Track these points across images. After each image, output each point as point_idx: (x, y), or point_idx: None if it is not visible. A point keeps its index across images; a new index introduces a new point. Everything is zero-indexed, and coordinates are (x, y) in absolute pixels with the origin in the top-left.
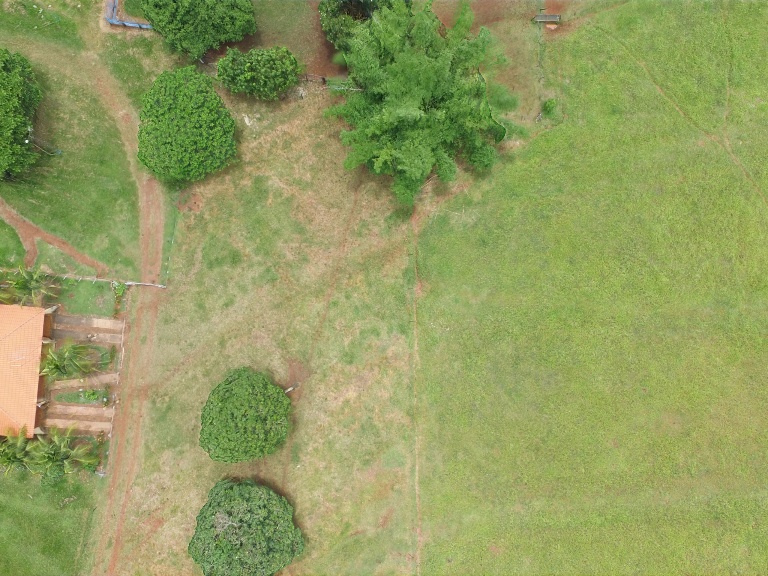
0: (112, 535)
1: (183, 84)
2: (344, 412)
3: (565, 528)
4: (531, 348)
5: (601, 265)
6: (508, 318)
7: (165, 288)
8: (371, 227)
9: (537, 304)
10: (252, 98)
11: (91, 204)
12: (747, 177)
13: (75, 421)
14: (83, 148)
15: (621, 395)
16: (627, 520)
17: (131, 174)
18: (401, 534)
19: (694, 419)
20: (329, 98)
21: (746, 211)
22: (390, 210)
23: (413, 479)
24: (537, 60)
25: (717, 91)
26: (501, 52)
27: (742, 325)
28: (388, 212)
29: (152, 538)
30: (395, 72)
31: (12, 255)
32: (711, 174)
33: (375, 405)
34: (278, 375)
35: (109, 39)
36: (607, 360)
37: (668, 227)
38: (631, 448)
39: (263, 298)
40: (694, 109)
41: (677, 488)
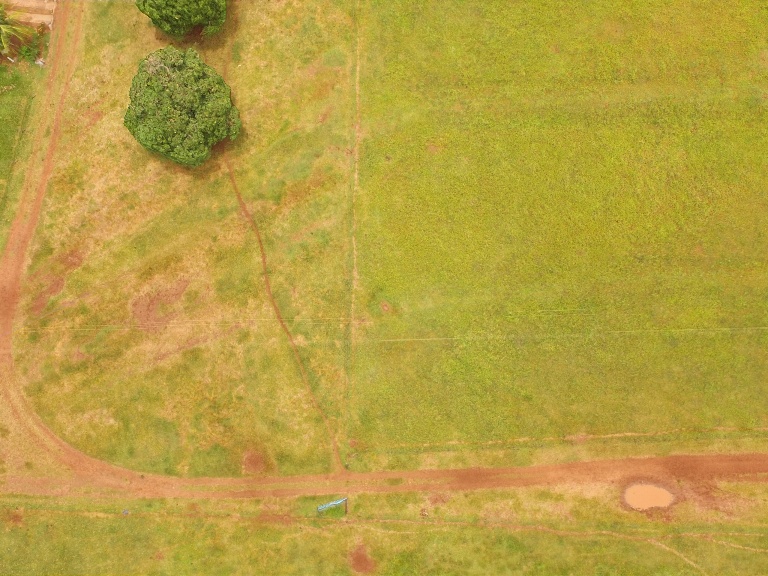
0: (50, 124)
1: None
2: (286, 12)
3: (504, 130)
4: None
5: None
6: None
7: None
8: None
9: None
10: None
11: None
12: None
13: (16, 12)
14: None
15: (564, 2)
16: (566, 122)
17: None
18: (340, 130)
19: (636, 27)
20: None
21: None
22: None
23: (354, 79)
24: None
25: None
26: None
27: None
28: None
29: (91, 130)
30: None
31: None
32: None
33: (318, 6)
34: None
35: None
36: None
37: None
38: (573, 53)
39: None
40: None
41: (617, 93)
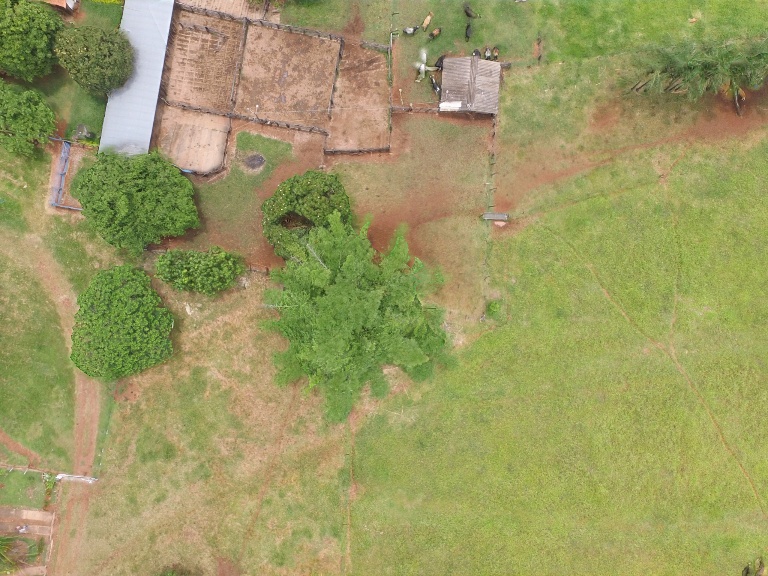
0: None
1: (119, 287)
2: None
3: None
4: (465, 556)
5: (540, 473)
6: (443, 525)
7: (97, 480)
8: (308, 424)
9: (472, 513)
10: (192, 292)
11: (27, 390)
12: (692, 387)
13: None
14: (22, 332)
15: None
16: None
17: (69, 361)
18: None
19: None
20: (272, 289)
21: (689, 423)
22: (328, 407)
23: None
24: (483, 258)
25: (664, 298)
26: (447, 249)
27: (681, 542)
28: (326, 409)
29: None
30: (325, 304)
31: None
32: (655, 383)
33: None
34: (207, 574)
35: (53, 221)
36: (542, 572)
37: (609, 436)
38: None
39: (196, 494)
40: (640, 316)
41: None
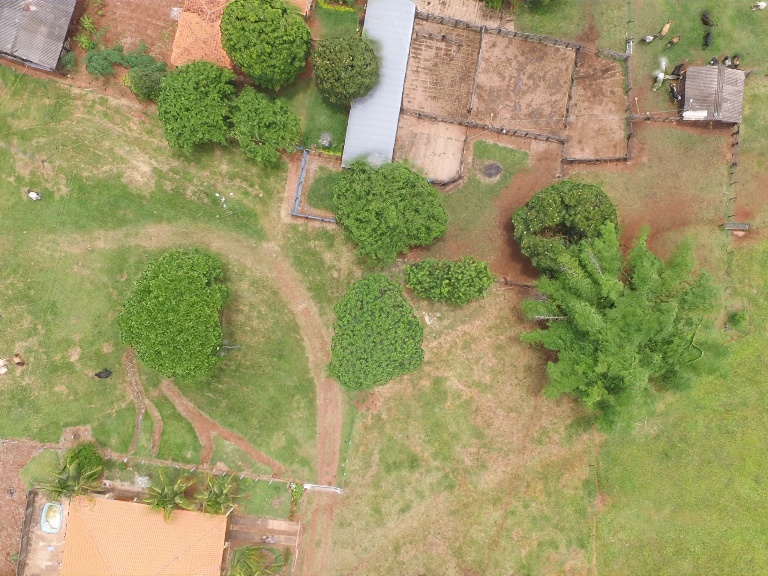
0: None
1: (379, 297)
2: None
3: None
4: (713, 569)
5: None
6: (691, 537)
7: (341, 490)
8: (551, 435)
9: (722, 525)
10: (438, 302)
11: (268, 400)
12: None
13: None
14: (261, 341)
15: None
16: None
17: (309, 370)
18: None
19: None
20: (511, 299)
21: None
22: (571, 418)
23: None
24: (724, 268)
25: None
26: None
27: None
28: (569, 420)
29: None
30: (614, 316)
31: (189, 451)
32: None
33: None
34: None
35: (290, 230)
36: None
37: None
38: None
39: (440, 504)
40: None
41: None
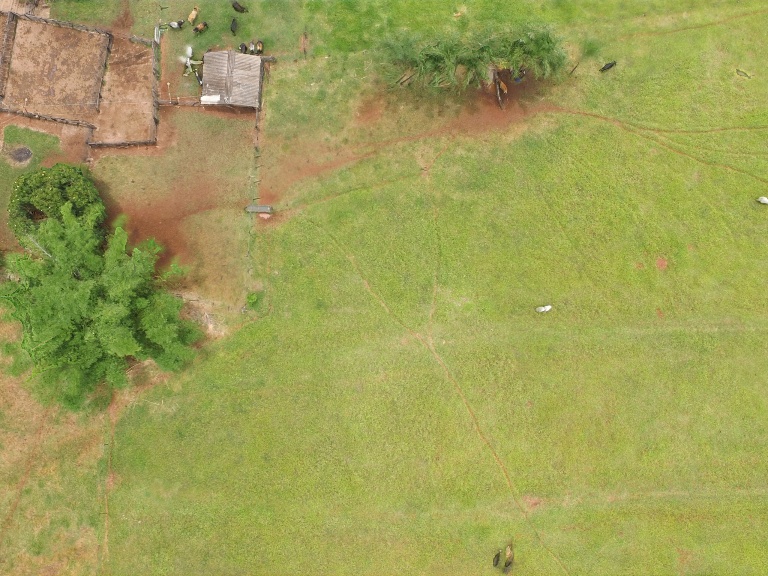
0: None
1: None
2: None
3: None
4: (221, 545)
5: (296, 463)
6: (199, 514)
7: None
8: (69, 415)
9: (227, 501)
10: None
11: None
12: (449, 377)
13: None
14: None
15: None
16: None
17: None
18: None
19: None
20: None
21: (445, 413)
22: (90, 398)
23: None
24: (247, 250)
25: (423, 289)
26: (211, 241)
27: (433, 530)
28: (88, 400)
29: None
30: (42, 294)
31: None
32: (412, 373)
33: None
34: None
35: None
36: (297, 560)
37: (366, 426)
38: None
39: None
40: (399, 307)
41: None
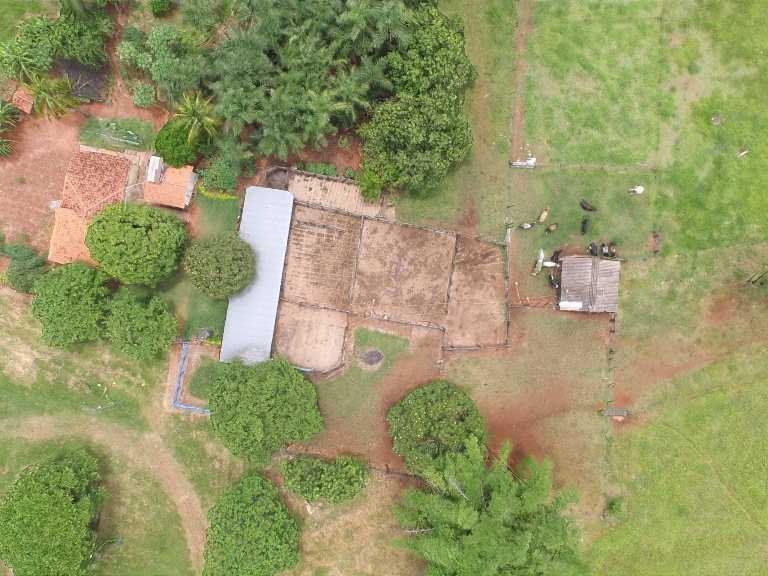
0: None
1: (250, 505)
2: None
3: None
4: None
5: None
6: None
7: None
8: None
9: None
10: None
11: None
12: None
13: None
14: (143, 534)
15: None
16: None
17: (191, 563)
18: None
19: None
20: (392, 487)
21: None
22: None
23: None
24: (603, 454)
25: None
26: (567, 446)
27: None
28: None
29: None
30: (471, 543)
31: None
32: None
33: None
34: None
35: (172, 420)
36: None
37: None
38: None
39: None
40: (762, 513)
41: None
